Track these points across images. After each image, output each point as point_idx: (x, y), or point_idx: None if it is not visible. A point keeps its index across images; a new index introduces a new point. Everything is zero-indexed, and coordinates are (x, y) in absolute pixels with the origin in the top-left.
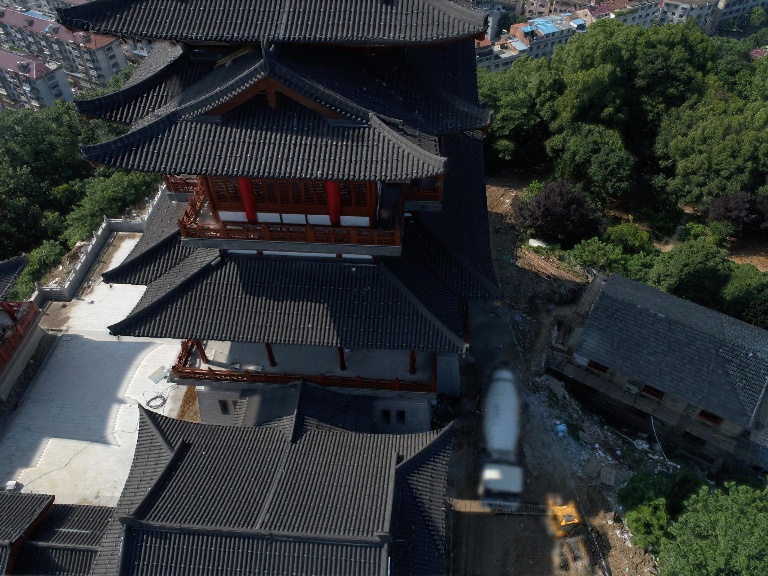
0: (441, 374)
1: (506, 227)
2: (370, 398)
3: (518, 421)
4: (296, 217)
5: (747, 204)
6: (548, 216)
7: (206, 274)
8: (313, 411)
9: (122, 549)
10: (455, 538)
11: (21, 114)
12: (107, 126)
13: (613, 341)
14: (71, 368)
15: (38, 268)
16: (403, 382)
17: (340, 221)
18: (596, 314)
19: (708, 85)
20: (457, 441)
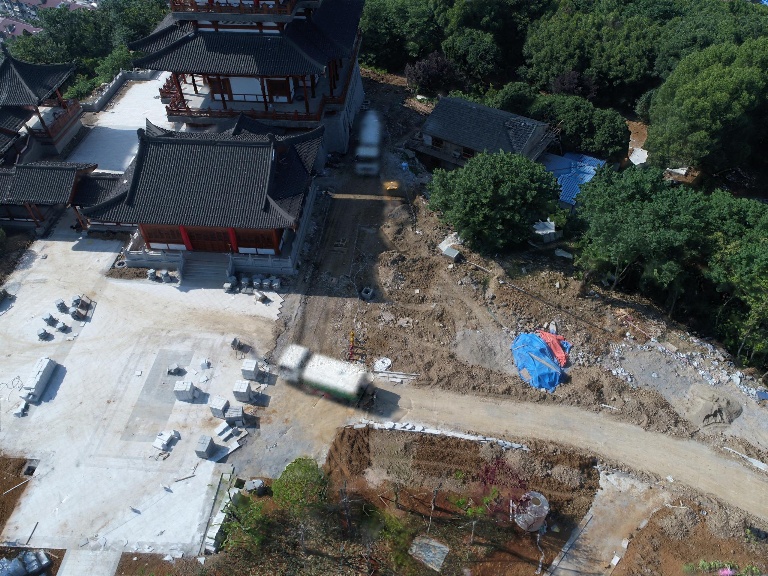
0: (332, 135)
1: (404, 91)
2: (283, 129)
3: (380, 164)
4: (235, 2)
5: (575, 79)
6: (427, 75)
7: (186, 42)
8: (247, 128)
9: (138, 148)
10: (330, 208)
11: (61, 8)
12: (122, 21)
13: (444, 124)
14: (101, 141)
15: (76, 95)
16: (300, 114)
17: (259, 5)
18: (436, 110)
19: (560, 4)
20: (340, 171)
